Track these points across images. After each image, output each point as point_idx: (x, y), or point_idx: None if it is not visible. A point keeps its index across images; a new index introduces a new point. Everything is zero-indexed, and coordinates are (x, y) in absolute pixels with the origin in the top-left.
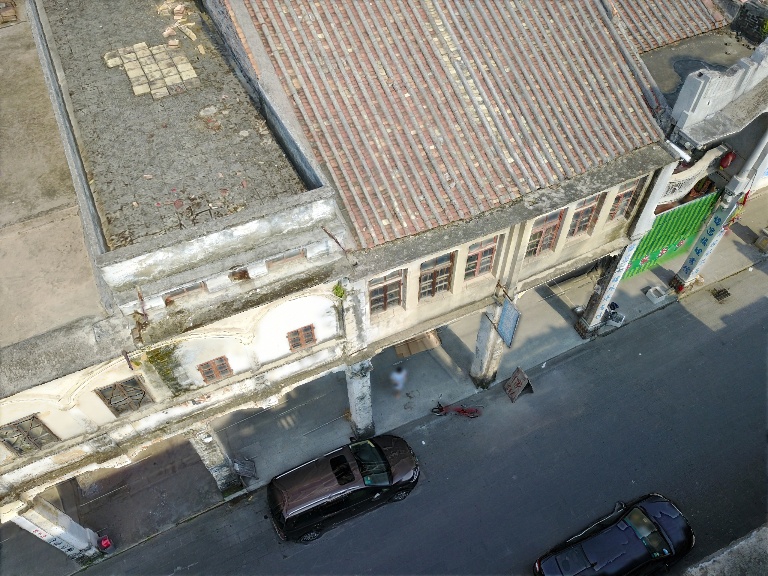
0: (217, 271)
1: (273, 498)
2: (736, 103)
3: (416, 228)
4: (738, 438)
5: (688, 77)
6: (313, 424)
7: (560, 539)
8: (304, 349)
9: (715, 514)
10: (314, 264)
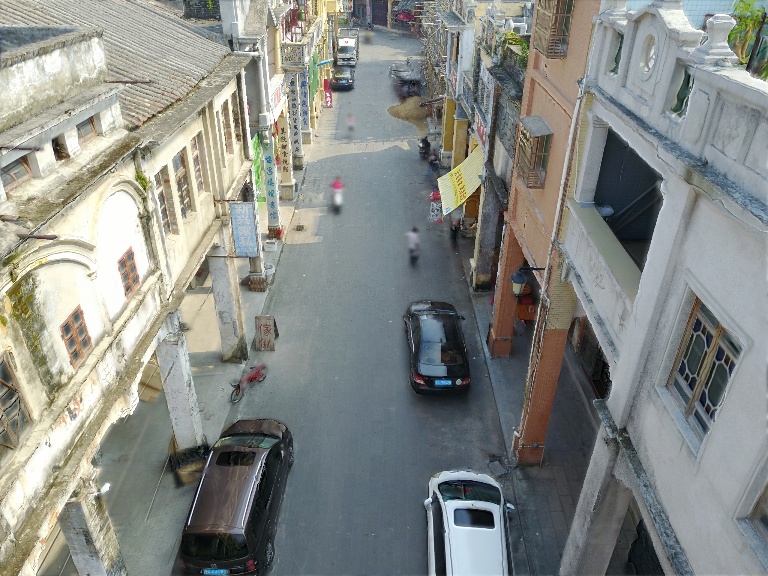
0: (54, 116)
1: (204, 549)
2: (248, 22)
3: (158, 105)
4: (398, 268)
5: None
6: (143, 505)
7: (404, 376)
8: (134, 294)
9: (437, 300)
10: (113, 138)
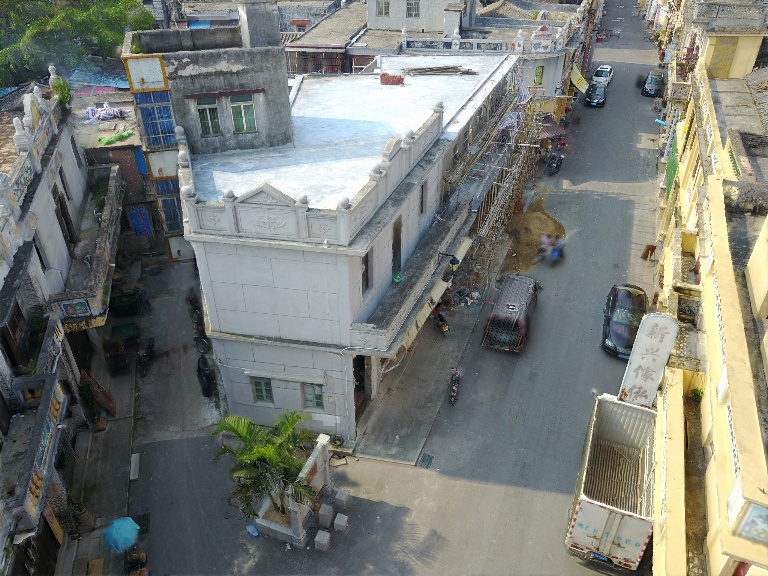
0: None
1: None
2: None
3: None
4: None
5: None
6: None
7: None
8: None
9: None
10: None
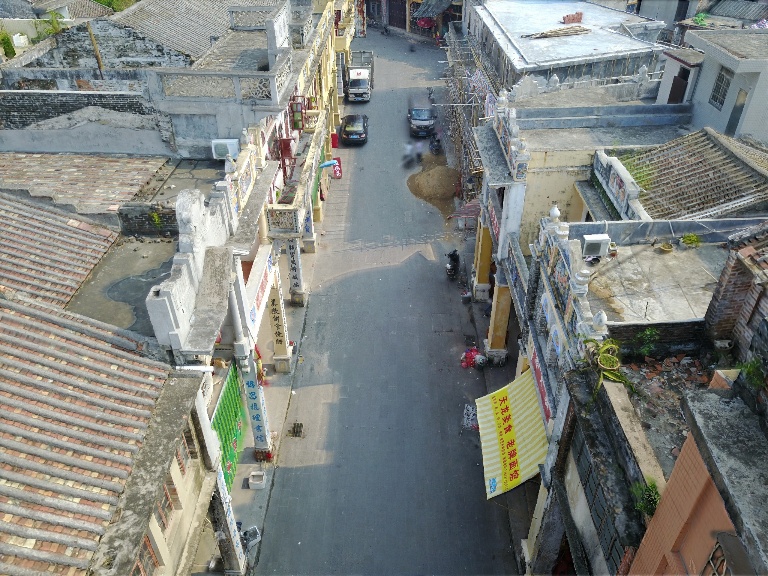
0: None
1: None
2: (201, 294)
3: None
4: (423, 526)
5: (147, 303)
6: None
7: None
8: None
9: None
10: None
